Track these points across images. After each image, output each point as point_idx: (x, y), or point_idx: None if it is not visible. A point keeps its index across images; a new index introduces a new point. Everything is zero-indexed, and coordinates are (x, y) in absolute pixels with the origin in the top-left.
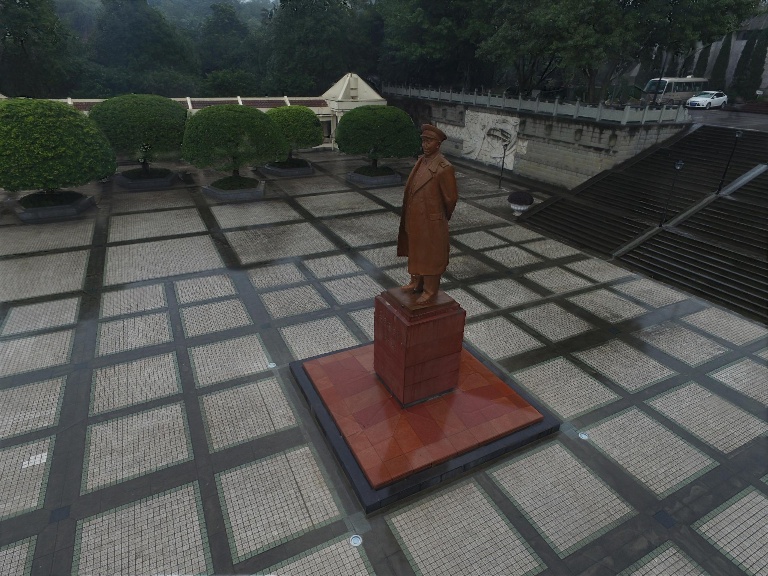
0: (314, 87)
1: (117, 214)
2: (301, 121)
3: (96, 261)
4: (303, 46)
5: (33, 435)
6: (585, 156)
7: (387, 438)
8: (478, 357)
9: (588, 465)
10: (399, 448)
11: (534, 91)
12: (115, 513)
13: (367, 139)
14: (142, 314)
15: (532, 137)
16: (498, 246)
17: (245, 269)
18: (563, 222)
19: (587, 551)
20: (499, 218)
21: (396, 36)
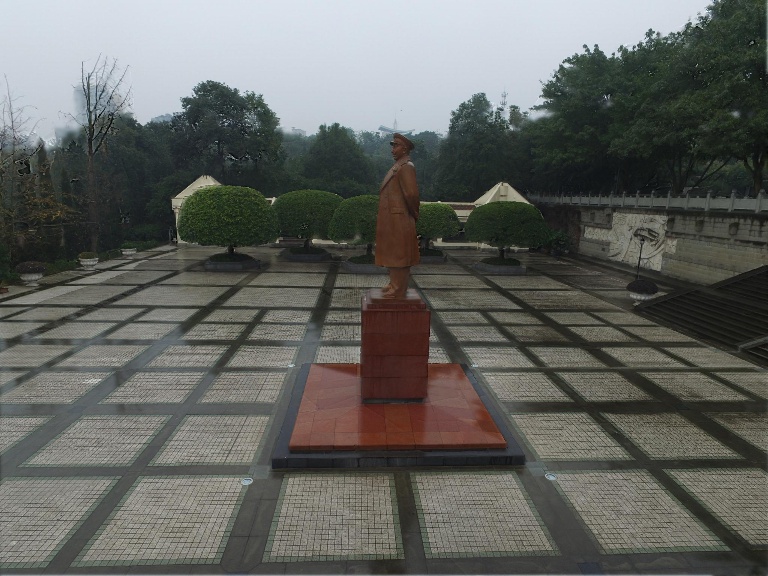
0: (468, 195)
1: (268, 272)
2: (437, 214)
3: (229, 293)
4: (462, 161)
5: (104, 369)
6: (743, 252)
7: (330, 419)
8: (480, 391)
9: (533, 499)
10: (334, 428)
11: (685, 188)
12: (107, 417)
13: (490, 228)
14: (230, 323)
15: (681, 235)
16: (591, 325)
17: (328, 310)
18: (688, 313)
19: (462, 562)
20: (613, 306)
21: (541, 145)
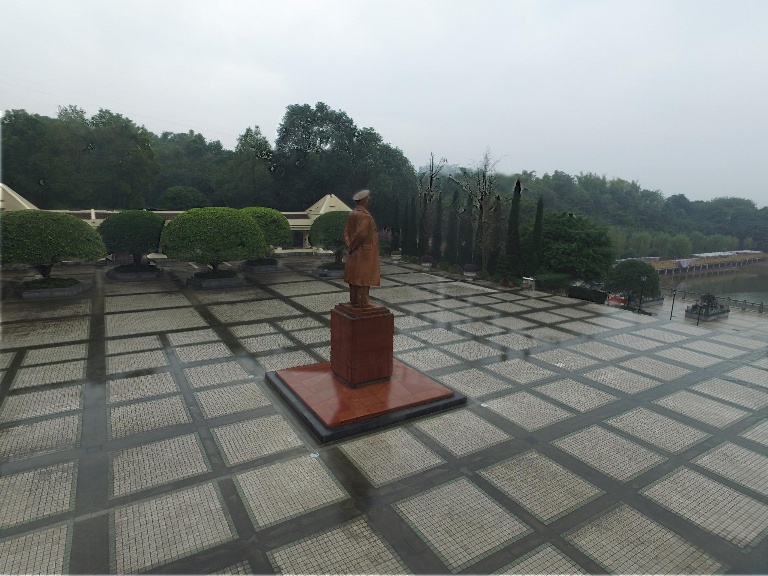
0: None
1: None
2: None
3: None
4: None
5: (582, 371)
6: None
7: None
8: (298, 404)
9: None
10: None
11: None
12: None
13: None
14: (695, 448)
15: None
16: None
17: (735, 570)
18: None
19: None
20: None
21: None
